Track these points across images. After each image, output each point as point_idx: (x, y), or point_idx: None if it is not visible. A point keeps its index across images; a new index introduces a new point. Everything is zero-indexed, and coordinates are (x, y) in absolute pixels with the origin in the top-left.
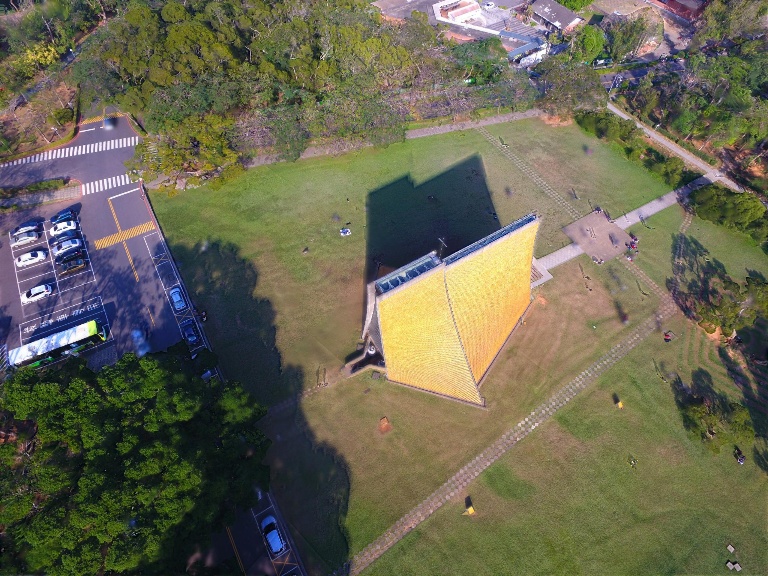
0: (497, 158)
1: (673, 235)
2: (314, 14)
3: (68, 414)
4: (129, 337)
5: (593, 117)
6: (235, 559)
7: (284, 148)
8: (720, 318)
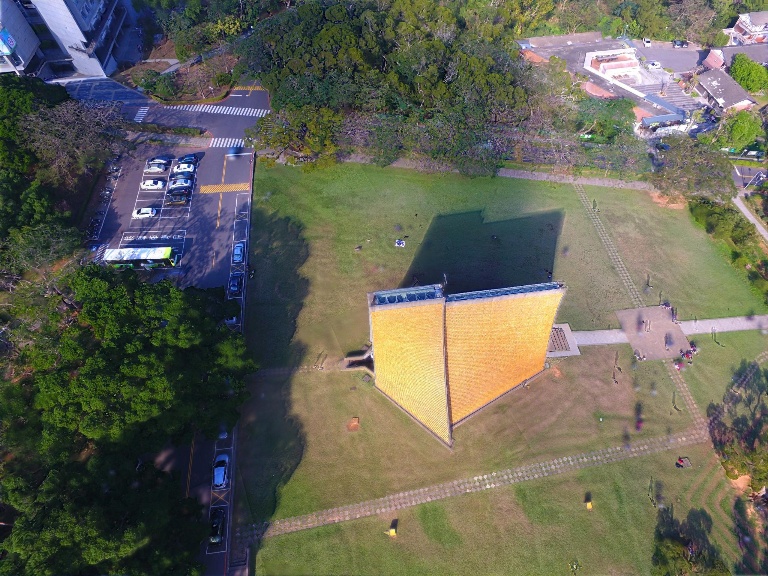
0: (581, 220)
1: (744, 361)
2: (460, 38)
3: (104, 308)
4: (191, 270)
5: (707, 208)
6: (180, 473)
7: (378, 153)
8: (750, 467)
